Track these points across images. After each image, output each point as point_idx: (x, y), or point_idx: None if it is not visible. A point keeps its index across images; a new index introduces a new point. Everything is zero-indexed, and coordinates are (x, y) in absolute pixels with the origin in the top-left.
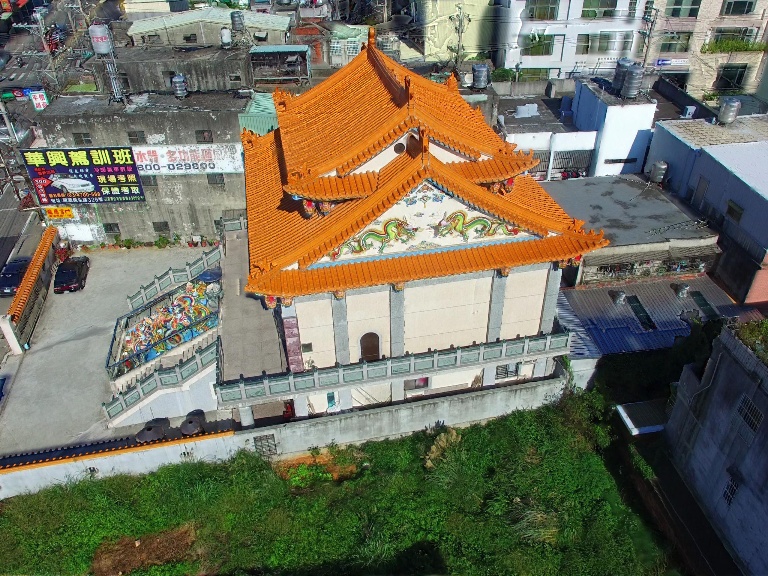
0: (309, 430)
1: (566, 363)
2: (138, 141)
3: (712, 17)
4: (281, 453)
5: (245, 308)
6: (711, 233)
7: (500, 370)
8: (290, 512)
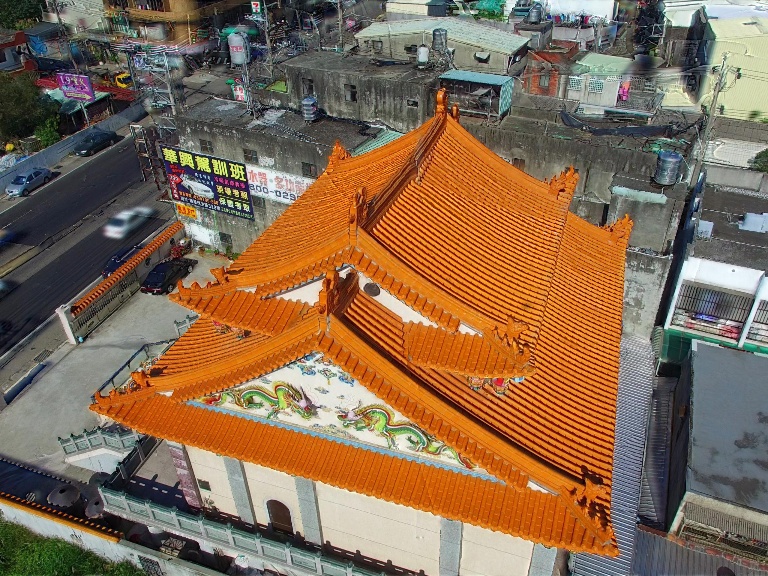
0: None
1: None
2: (252, 160)
3: None
4: None
5: None
6: None
7: None
8: None
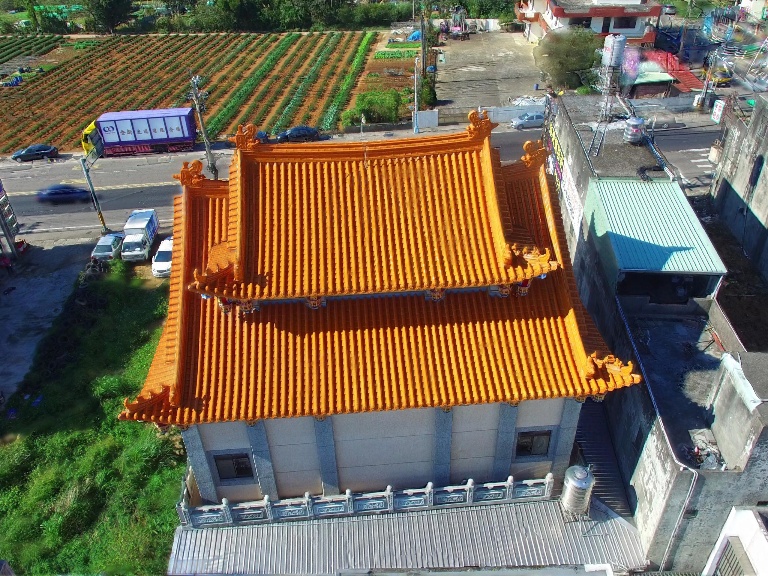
0: None
1: None
2: None
3: None
4: None
5: None
6: None
7: None
8: None
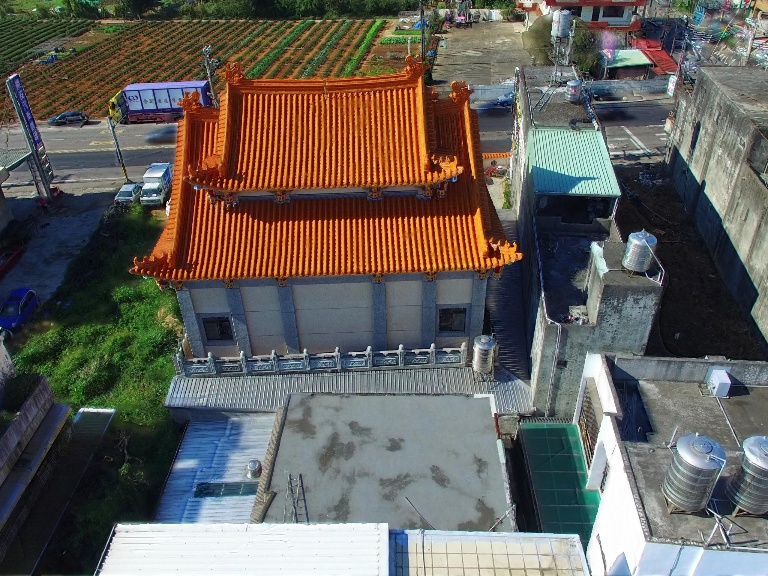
0: None
1: None
2: None
3: None
4: None
5: None
6: None
7: None
8: None
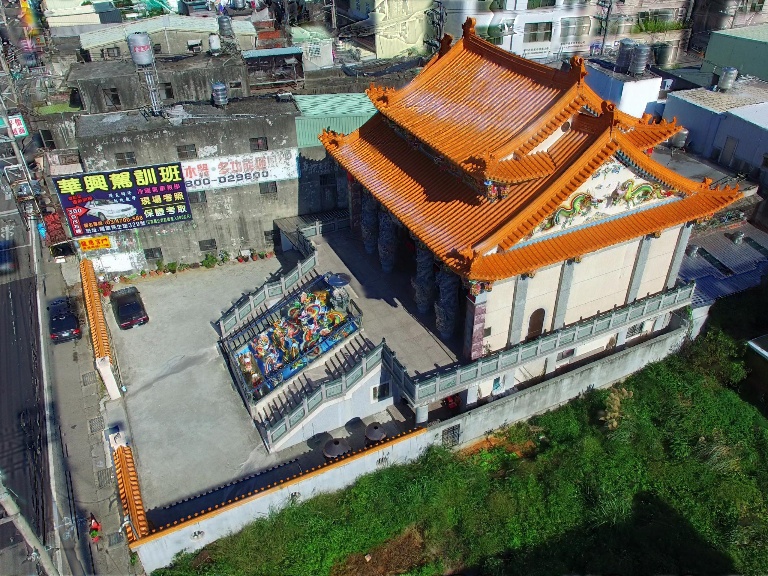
0: (489, 414)
1: (688, 313)
2: (187, 155)
3: (635, 2)
4: (462, 442)
5: (373, 309)
6: (752, 185)
7: (629, 329)
8: (509, 493)
